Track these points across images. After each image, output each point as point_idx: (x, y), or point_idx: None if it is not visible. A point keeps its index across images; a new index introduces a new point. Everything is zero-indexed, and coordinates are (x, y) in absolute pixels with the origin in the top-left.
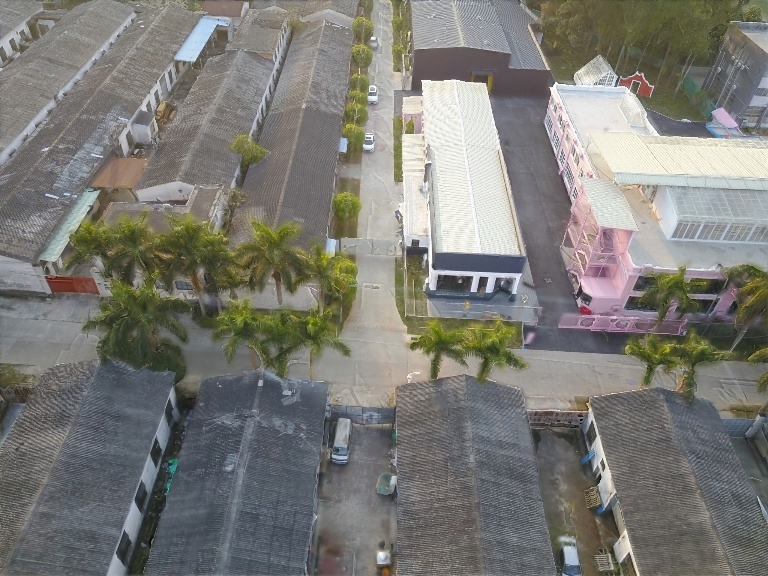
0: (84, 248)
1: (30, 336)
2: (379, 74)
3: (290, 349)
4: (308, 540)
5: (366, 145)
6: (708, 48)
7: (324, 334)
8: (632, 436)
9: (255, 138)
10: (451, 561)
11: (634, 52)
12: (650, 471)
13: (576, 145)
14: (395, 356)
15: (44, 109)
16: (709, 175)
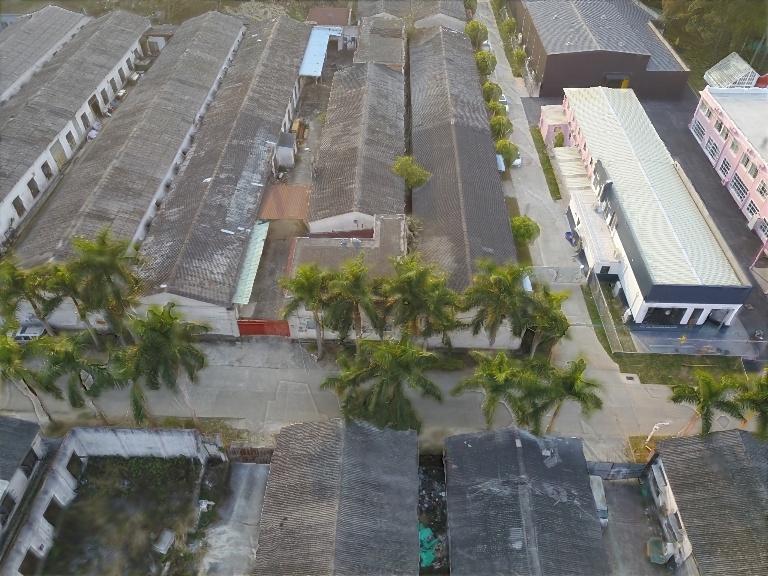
0: (301, 295)
1: (231, 385)
2: (500, 80)
3: (547, 405)
4: None
5: None
6: None
7: (591, 390)
8: None
9: None
10: None
11: None
12: None
13: (752, 155)
14: (616, 399)
15: (187, 134)
16: None
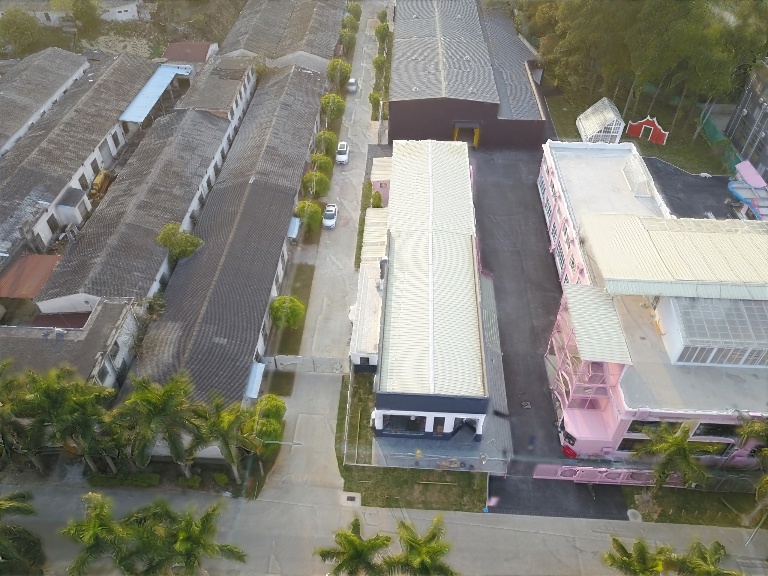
0: None
1: None
2: (354, 124)
3: (161, 563)
4: None
5: (326, 220)
6: (733, 83)
7: (199, 552)
8: None
9: (193, 221)
10: None
11: (647, 88)
12: None
13: (567, 225)
14: (323, 526)
15: None
16: (725, 281)
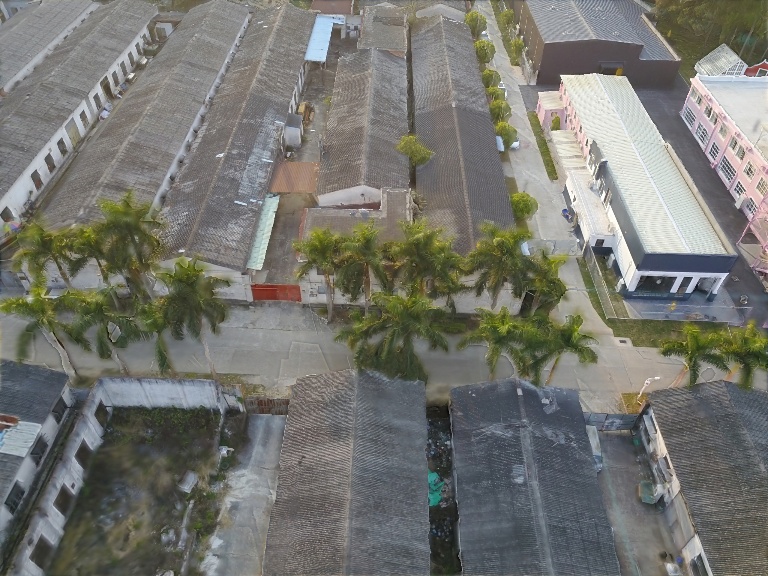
0: (315, 257)
1: (246, 345)
2: (498, 69)
3: (546, 357)
4: (615, 553)
5: None
6: None
7: (587, 341)
8: None
9: None
10: None
11: None
12: None
13: (740, 138)
14: (610, 360)
15: (198, 114)
16: None
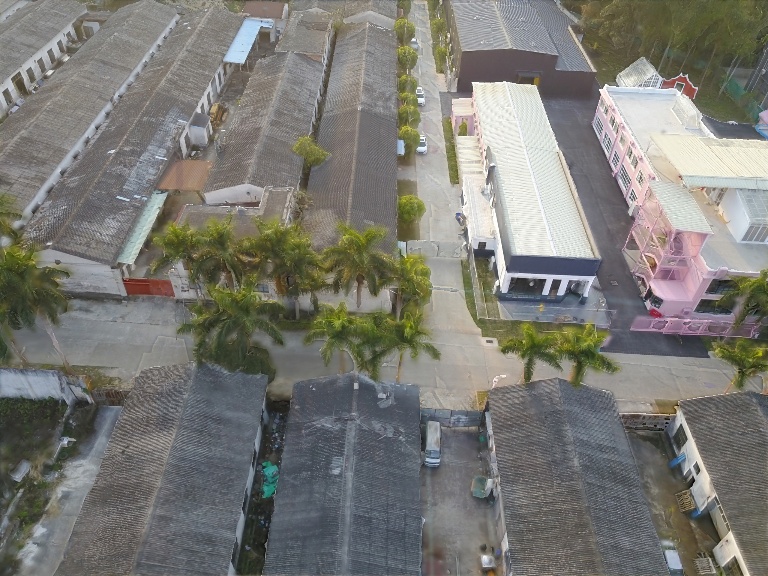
0: (171, 251)
1: (111, 338)
2: (423, 76)
3: (384, 352)
4: (420, 543)
5: (419, 147)
6: None
7: (421, 337)
8: (728, 440)
9: (313, 140)
10: (568, 565)
11: None
12: (751, 475)
13: (634, 147)
14: (473, 359)
15: (102, 111)
16: None
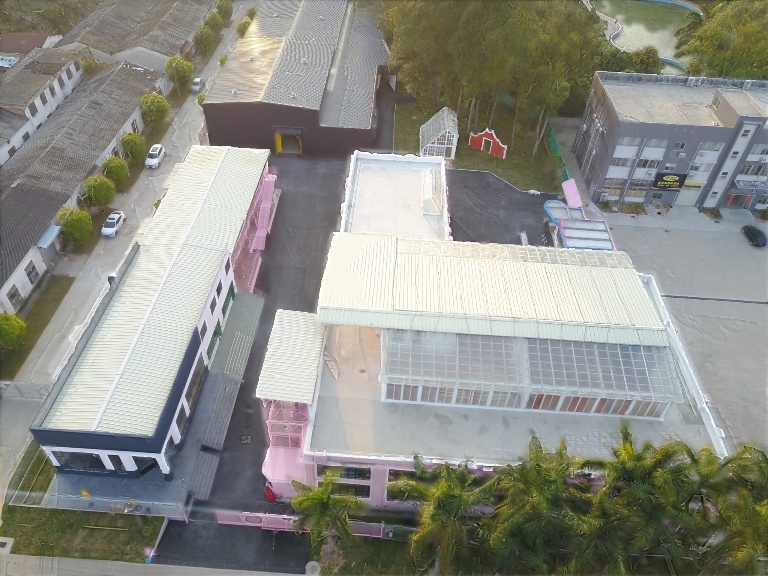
0: None
1: None
2: (184, 126)
3: None
4: None
5: (106, 228)
6: None
7: None
8: None
9: None
10: None
11: (506, 98)
12: None
13: None
14: None
15: None
16: (446, 312)
